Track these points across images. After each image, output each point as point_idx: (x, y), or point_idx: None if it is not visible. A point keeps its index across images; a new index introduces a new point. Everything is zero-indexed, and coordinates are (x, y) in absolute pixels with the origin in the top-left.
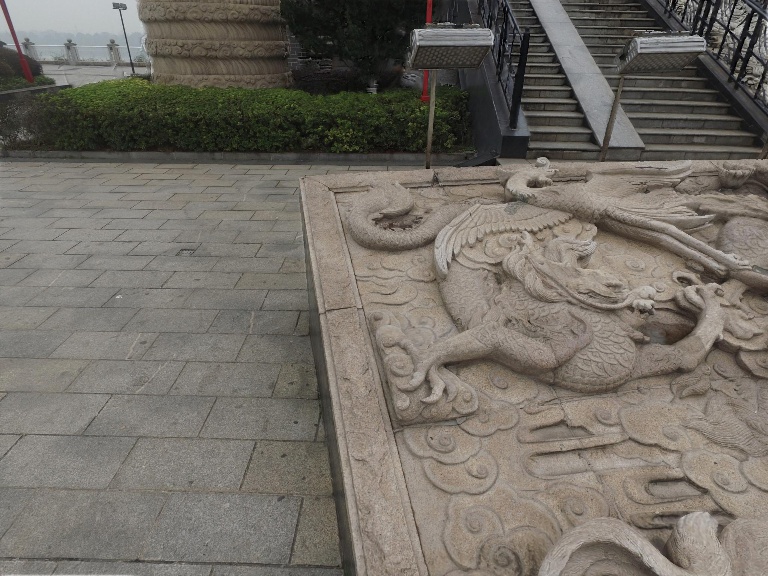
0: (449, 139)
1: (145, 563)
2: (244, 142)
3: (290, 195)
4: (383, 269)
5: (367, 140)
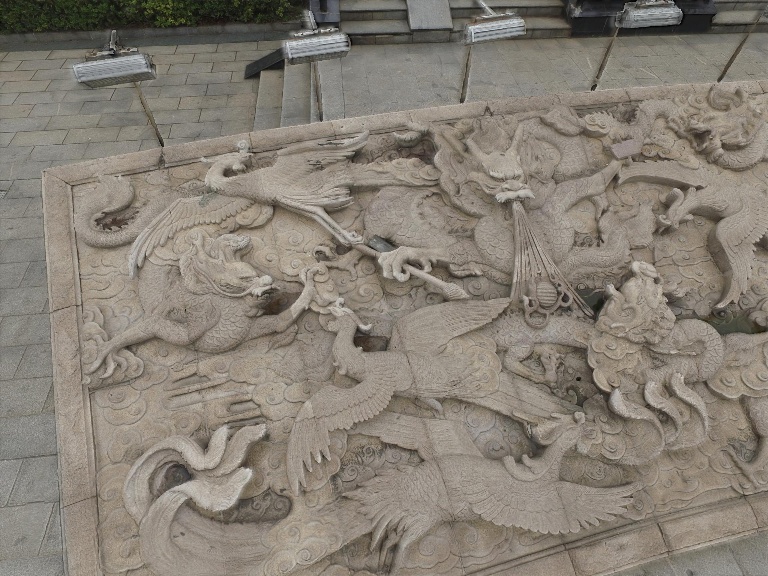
0: (280, 6)
1: None
2: (54, 20)
3: (106, 102)
4: (102, 266)
5: (191, 12)
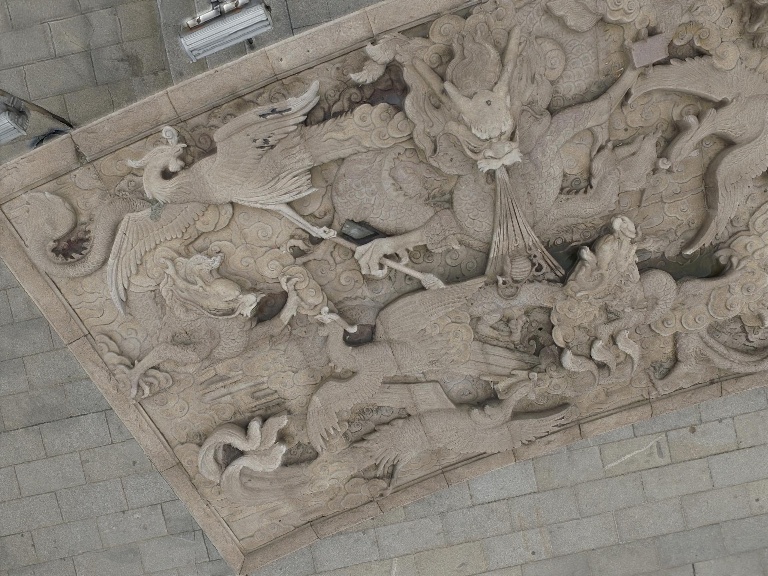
0: None
1: (75, 417)
2: None
3: None
4: (86, 293)
5: None
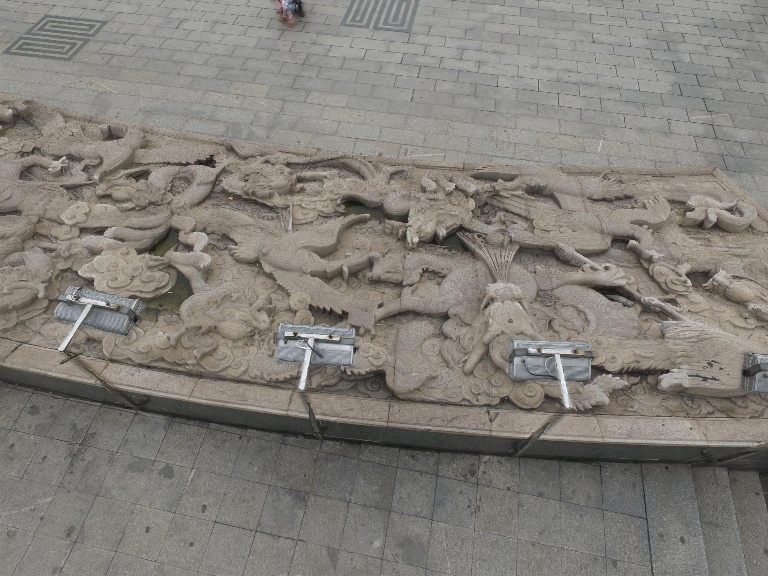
0: None
1: None
2: None
3: None
4: None
5: None
